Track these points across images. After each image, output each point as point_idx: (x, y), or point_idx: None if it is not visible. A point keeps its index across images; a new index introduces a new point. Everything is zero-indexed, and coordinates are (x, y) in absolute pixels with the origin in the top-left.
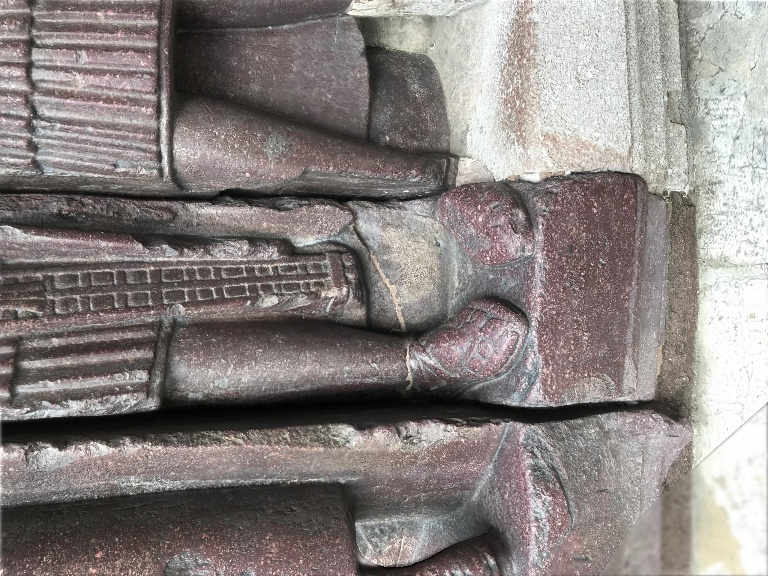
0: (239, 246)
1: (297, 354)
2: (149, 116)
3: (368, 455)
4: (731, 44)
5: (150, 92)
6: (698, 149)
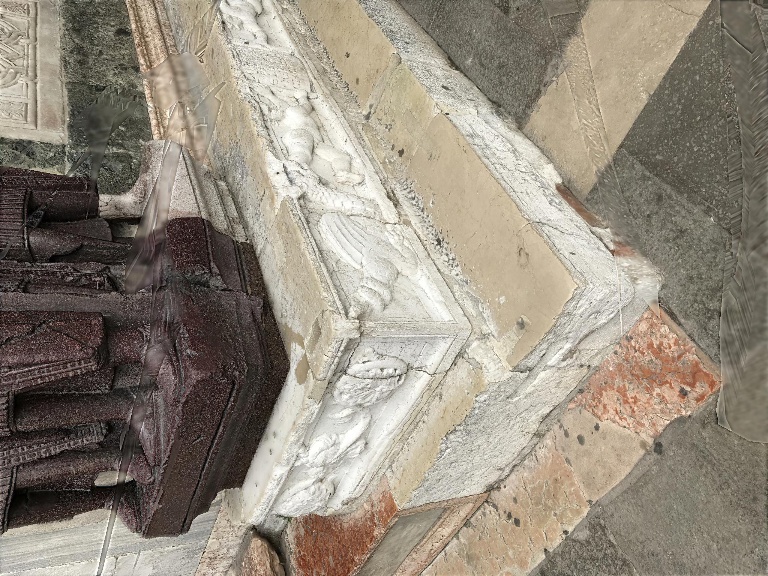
0: (56, 265)
1: (81, 289)
2: (20, 225)
3: (110, 302)
4: (245, 197)
5: (20, 219)
6: (248, 230)
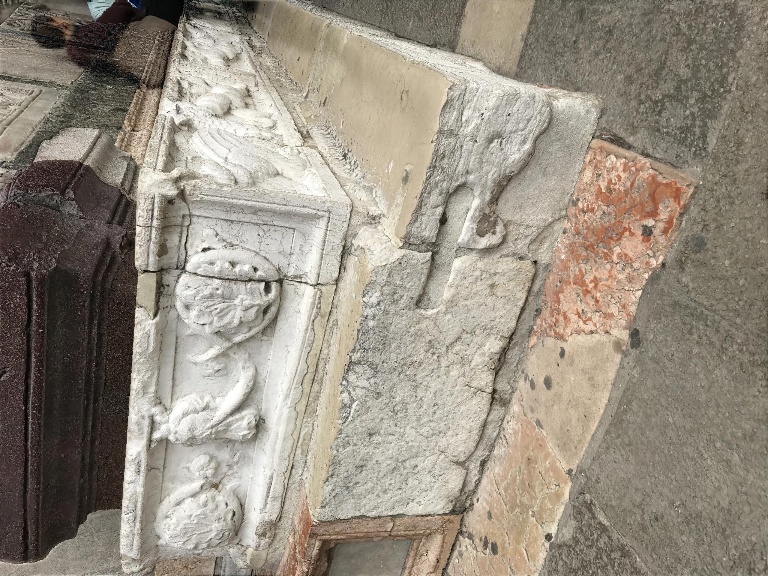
0: None
1: None
2: None
3: None
4: None
5: None
6: None
